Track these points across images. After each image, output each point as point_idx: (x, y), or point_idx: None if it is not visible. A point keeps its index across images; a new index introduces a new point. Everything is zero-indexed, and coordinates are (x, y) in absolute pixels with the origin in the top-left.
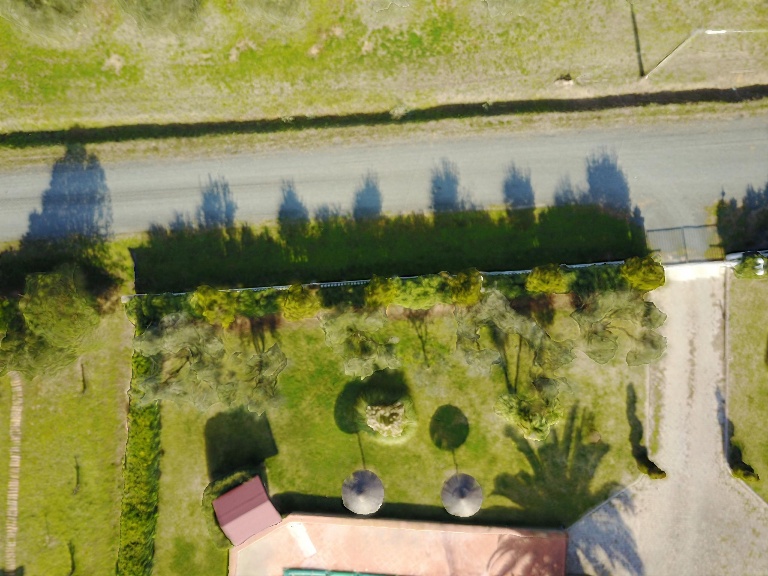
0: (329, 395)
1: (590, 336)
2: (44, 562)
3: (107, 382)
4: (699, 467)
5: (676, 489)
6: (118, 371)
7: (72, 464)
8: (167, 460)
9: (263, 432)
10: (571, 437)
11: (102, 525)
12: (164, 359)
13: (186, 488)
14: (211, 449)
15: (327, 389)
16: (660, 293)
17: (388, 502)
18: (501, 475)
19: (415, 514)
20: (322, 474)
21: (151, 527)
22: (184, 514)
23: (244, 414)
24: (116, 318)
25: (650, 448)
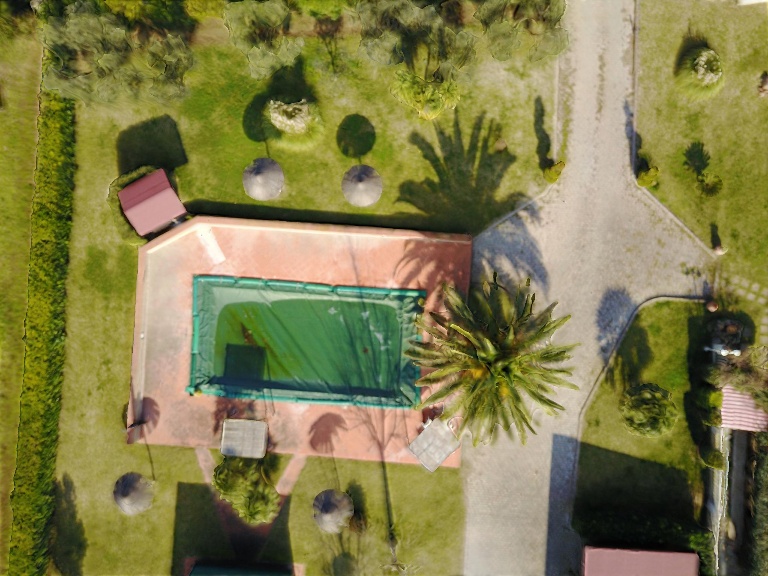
0: (238, 106)
1: (489, 25)
2: None
3: (23, 102)
4: (606, 180)
5: (583, 202)
6: (35, 94)
7: None
8: (81, 173)
9: (173, 142)
10: (477, 147)
11: (20, 241)
12: (71, 57)
13: (99, 198)
14: (123, 160)
15: (236, 101)
16: (570, 9)
17: (295, 209)
18: (407, 182)
19: (322, 220)
20: (231, 181)
21: (63, 231)
22: (97, 222)
23: (155, 126)
24: (32, 39)
25: (558, 162)
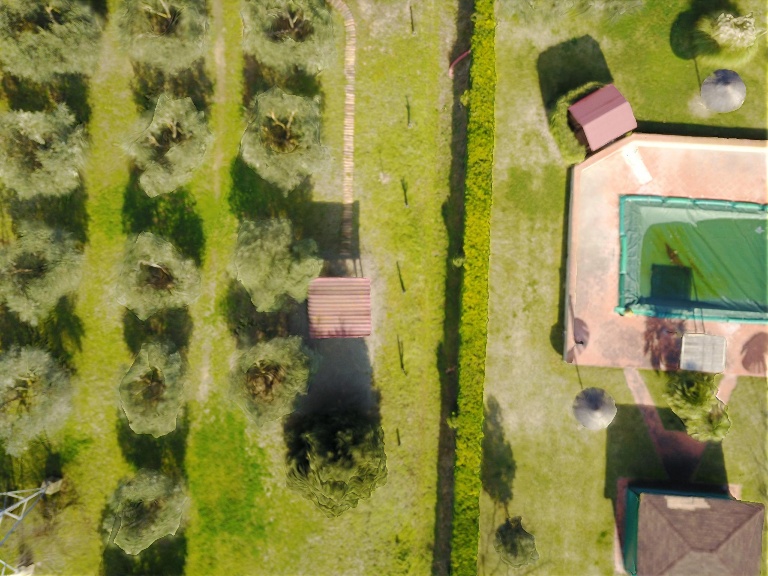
0: (663, 25)
1: None
2: (379, 197)
3: (432, 27)
4: None
5: None
6: (440, 19)
7: (403, 103)
8: (499, 95)
9: (597, 63)
10: None
11: (430, 166)
12: None
13: (521, 119)
14: (545, 81)
15: (660, 20)
16: None
17: (726, 127)
18: None
19: (754, 137)
20: (659, 100)
21: (492, 152)
22: (520, 144)
23: (576, 47)
24: None
25: None
